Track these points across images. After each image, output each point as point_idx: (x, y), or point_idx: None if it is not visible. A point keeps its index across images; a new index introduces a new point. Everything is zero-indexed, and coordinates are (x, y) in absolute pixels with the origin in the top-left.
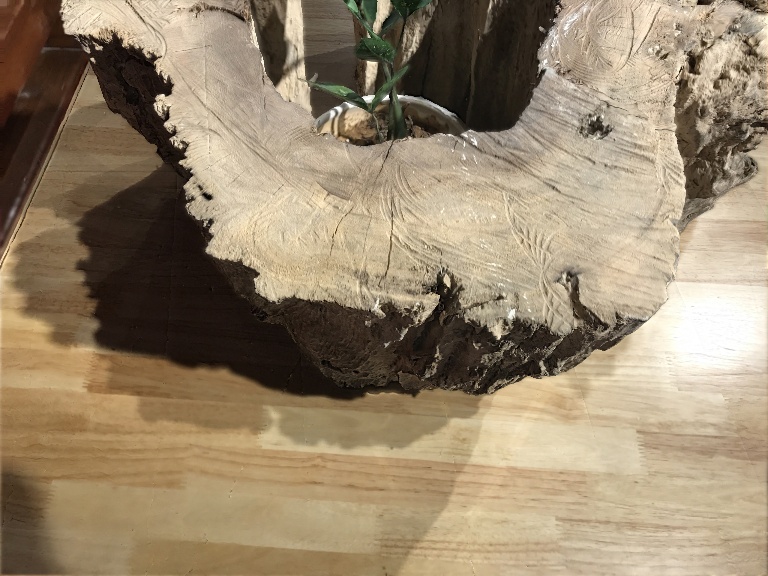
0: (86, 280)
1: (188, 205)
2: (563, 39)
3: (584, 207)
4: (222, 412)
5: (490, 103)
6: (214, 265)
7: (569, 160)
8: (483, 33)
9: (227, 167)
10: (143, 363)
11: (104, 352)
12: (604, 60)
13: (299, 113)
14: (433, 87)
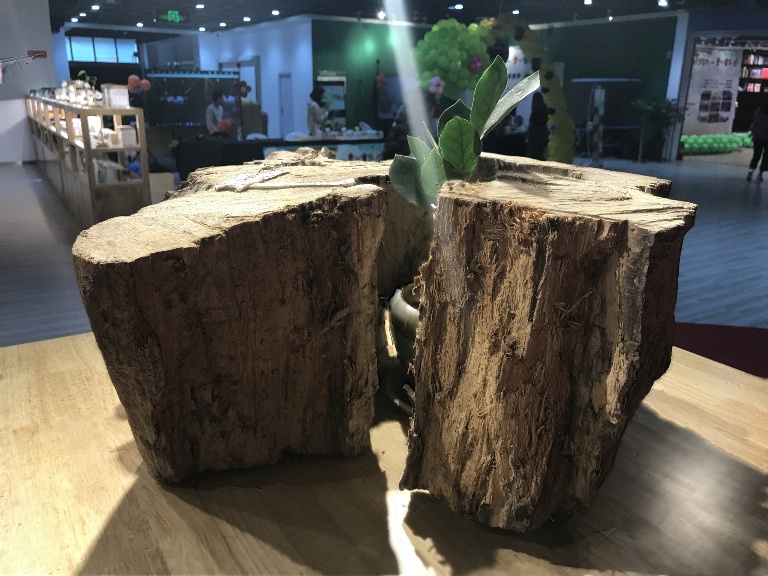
0: None
1: None
2: None
3: None
4: (680, 405)
5: None
6: (620, 463)
7: None
8: None
9: None
10: None
11: None
12: None
13: None
14: None
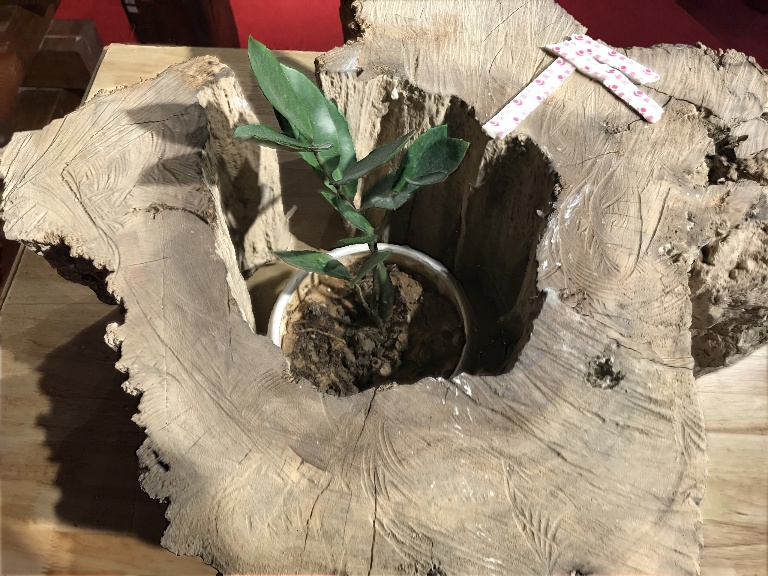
0: (47, 439)
1: (141, 478)
2: (564, 231)
3: (594, 482)
4: None
5: (482, 243)
6: None
7: (576, 417)
8: (474, 186)
9: (186, 426)
10: (108, 541)
11: (65, 529)
12: (610, 262)
13: (269, 351)
14: (421, 220)
